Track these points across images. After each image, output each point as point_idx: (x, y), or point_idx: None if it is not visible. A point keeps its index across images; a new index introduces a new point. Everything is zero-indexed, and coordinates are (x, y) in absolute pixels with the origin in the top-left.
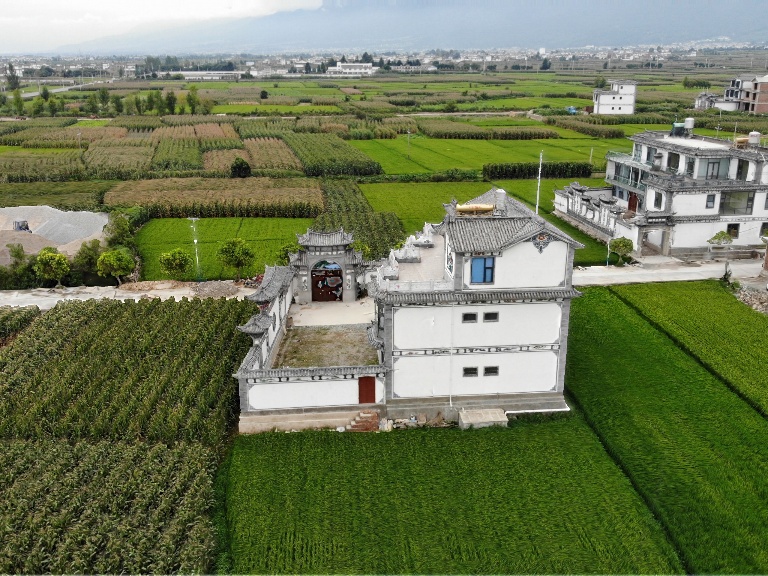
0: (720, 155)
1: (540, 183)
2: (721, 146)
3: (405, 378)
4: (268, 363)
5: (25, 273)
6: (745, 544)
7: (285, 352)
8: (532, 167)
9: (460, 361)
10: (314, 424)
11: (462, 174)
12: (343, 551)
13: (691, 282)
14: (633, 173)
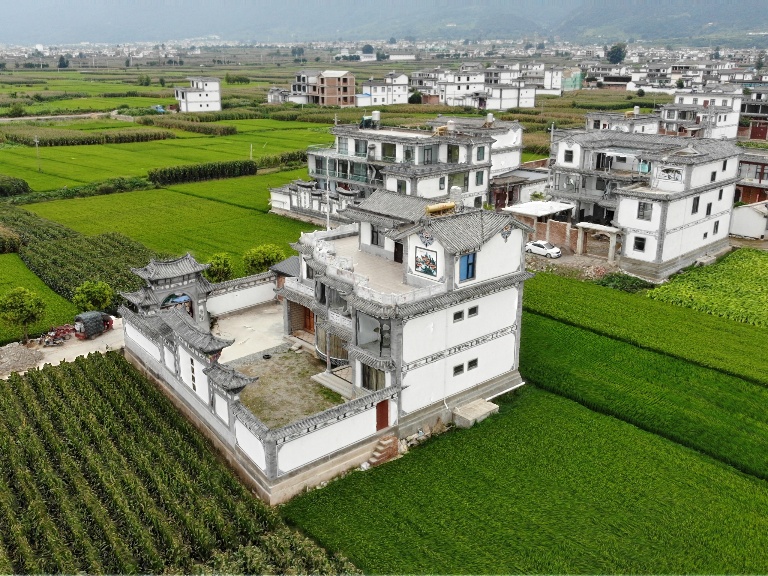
0: (432, 142)
1: (219, 184)
2: (419, 134)
3: (411, 392)
4: None
5: None
6: (758, 442)
7: None
8: (202, 169)
9: (451, 361)
10: (341, 468)
11: (130, 183)
12: (538, 572)
13: None
14: (340, 165)
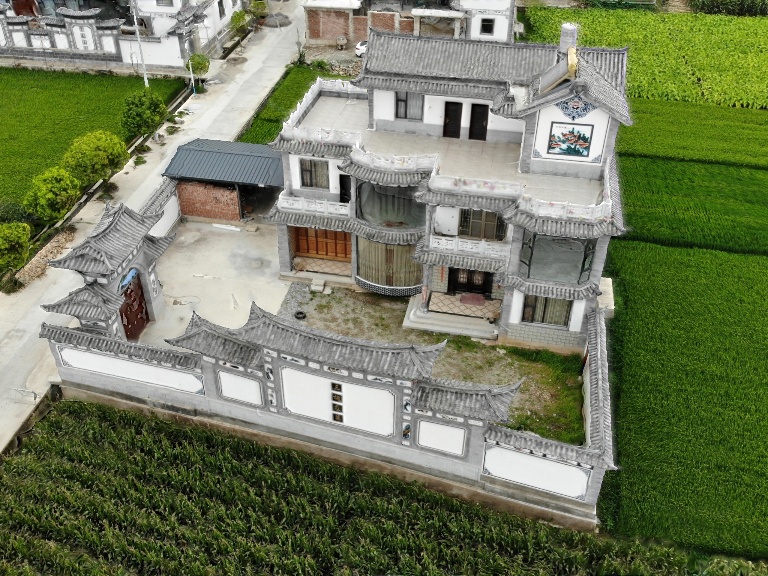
0: None
1: None
2: None
3: None
4: None
5: None
6: None
7: None
8: None
9: None
10: None
11: None
12: None
13: (290, 78)
14: None
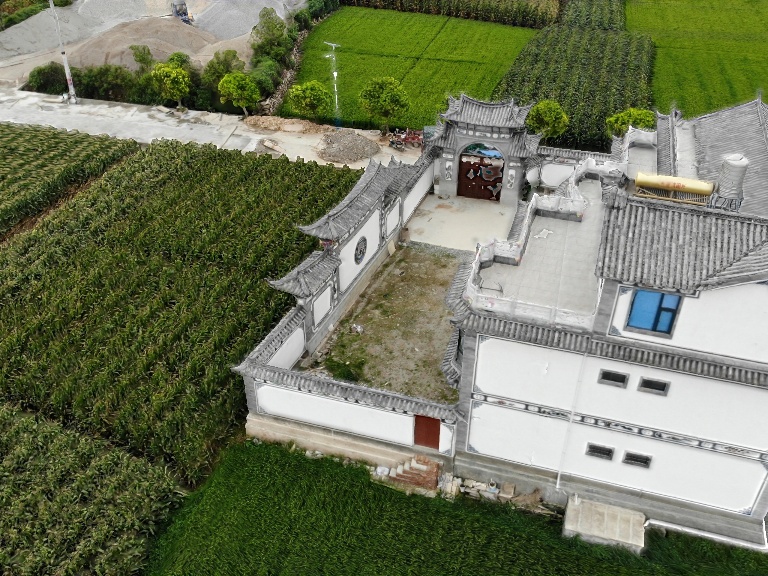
0: None
1: None
2: None
3: (489, 431)
4: (332, 317)
5: (149, 84)
6: None
7: (373, 292)
8: None
9: (584, 433)
10: (346, 453)
11: None
12: None
13: None
14: None
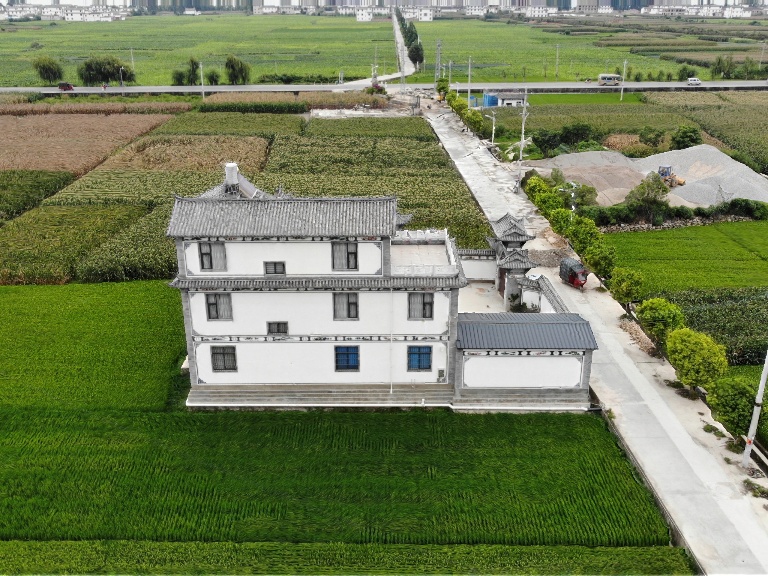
0: None
1: None
2: None
3: None
4: None
5: None
6: None
7: None
8: None
9: None
10: None
11: None
12: None
13: None
14: None
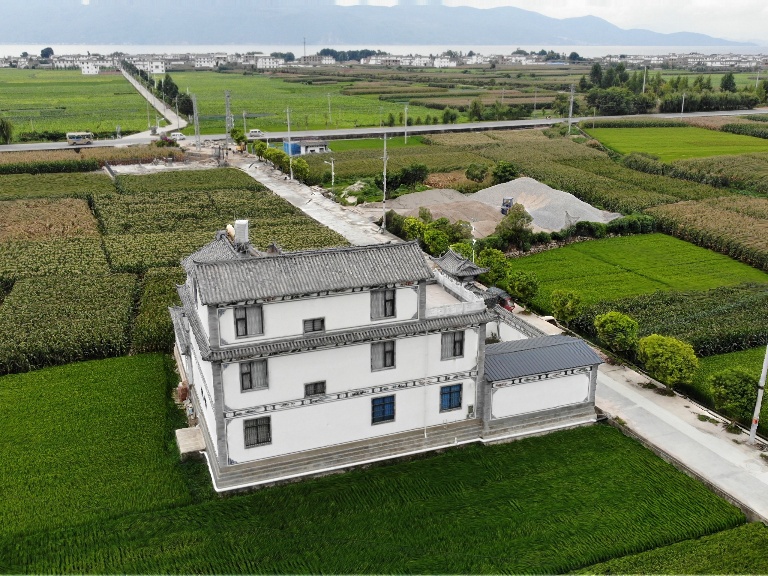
0: None
1: None
2: None
3: None
4: None
5: None
6: None
7: None
8: None
9: None
10: (180, 373)
11: None
12: None
13: None
14: None
